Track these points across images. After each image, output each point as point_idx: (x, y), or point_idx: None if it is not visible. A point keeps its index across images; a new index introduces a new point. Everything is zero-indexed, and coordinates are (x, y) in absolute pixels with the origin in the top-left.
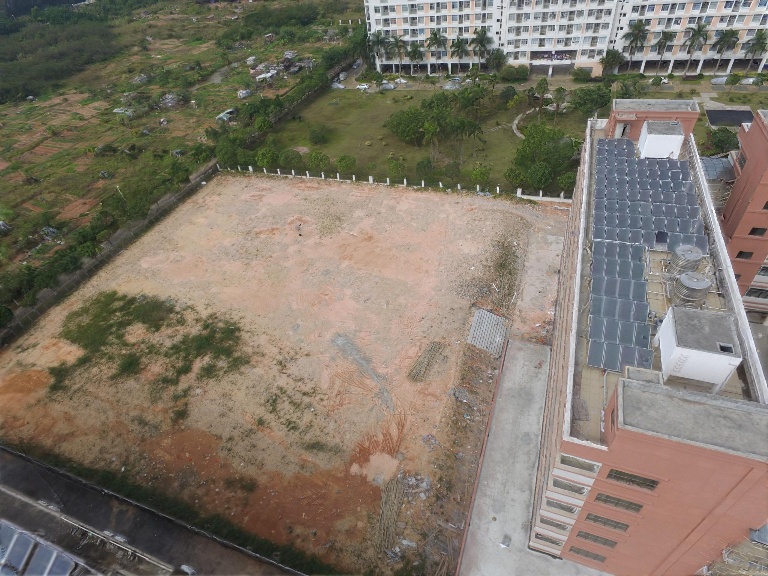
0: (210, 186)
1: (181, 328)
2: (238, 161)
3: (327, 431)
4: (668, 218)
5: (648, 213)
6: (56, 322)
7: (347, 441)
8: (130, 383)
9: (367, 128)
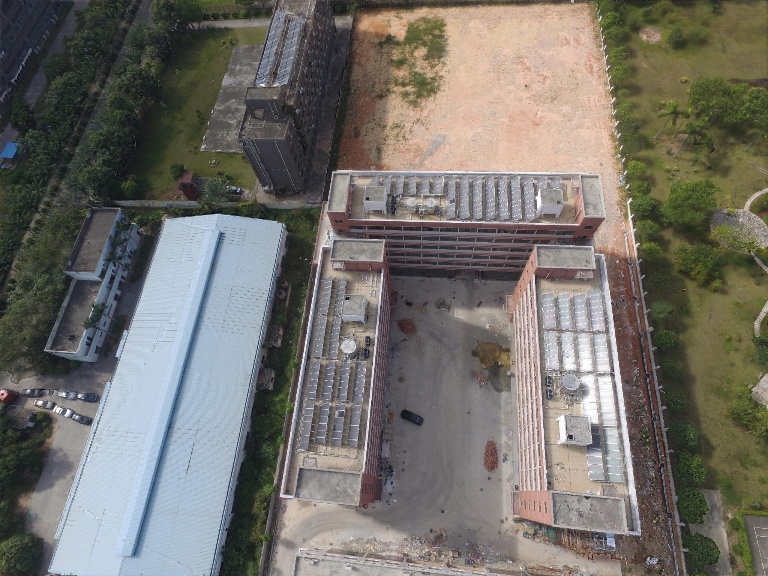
0: (570, 7)
1: (429, 69)
2: (599, 6)
3: (387, 152)
4: (468, 204)
5: (475, 199)
6: (417, 16)
7: (384, 161)
8: (391, 69)
9: (721, 68)
